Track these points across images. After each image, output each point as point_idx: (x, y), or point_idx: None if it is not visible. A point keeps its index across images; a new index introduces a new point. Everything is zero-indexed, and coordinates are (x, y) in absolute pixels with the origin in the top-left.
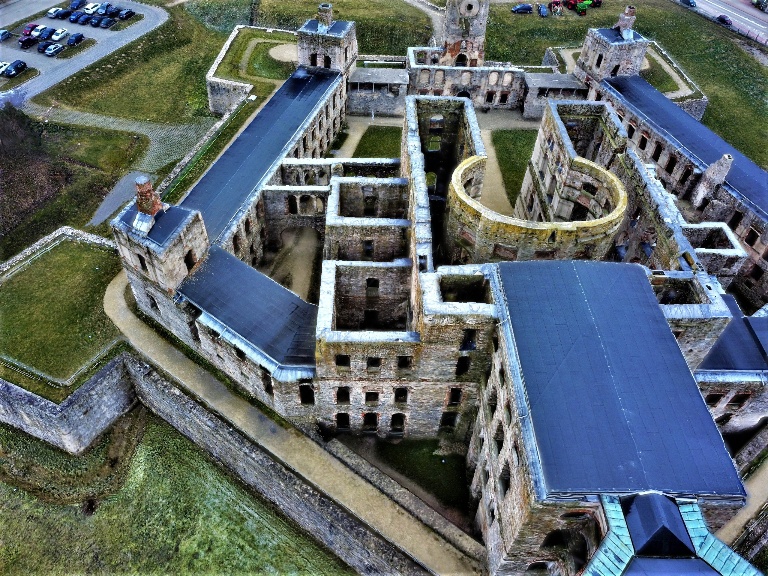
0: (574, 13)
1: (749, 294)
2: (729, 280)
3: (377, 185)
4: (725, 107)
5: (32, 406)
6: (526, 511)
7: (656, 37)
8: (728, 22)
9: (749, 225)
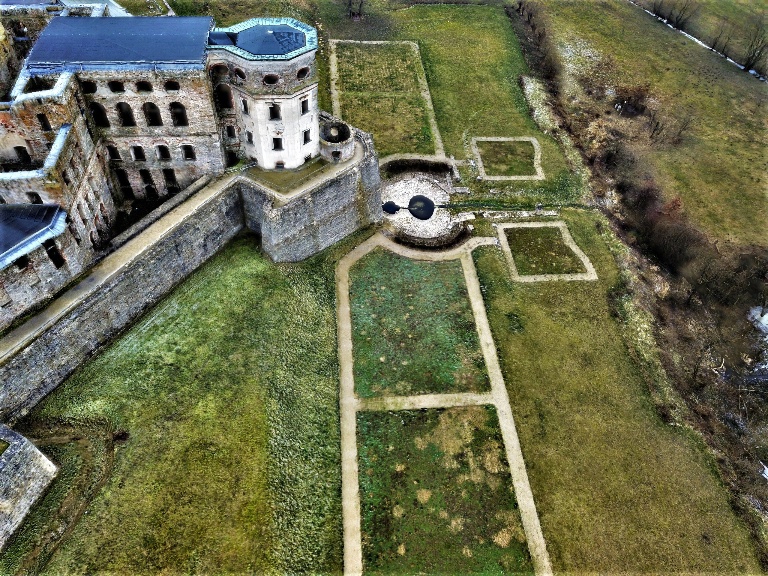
0: None
1: None
2: None
3: None
4: None
5: (4, 469)
6: (206, 86)
7: None
8: None
9: None
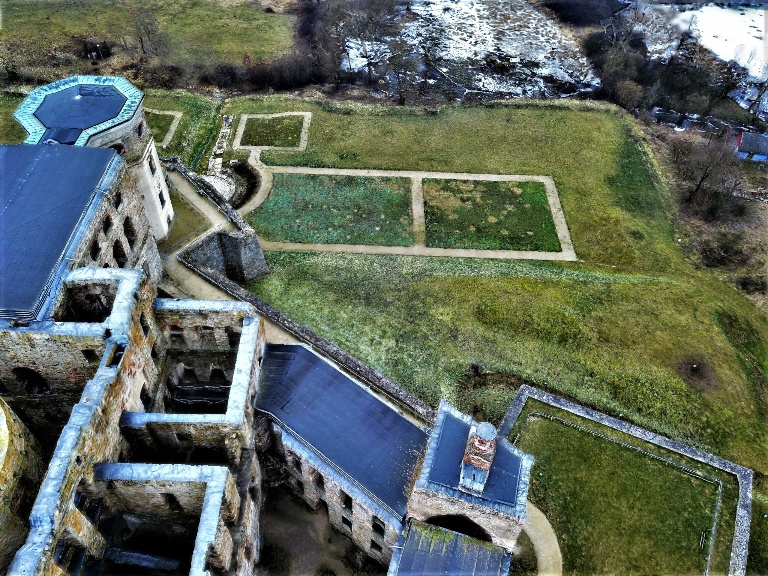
0: None
1: None
2: None
3: None
4: None
5: (553, 395)
6: None
7: None
8: None
9: None
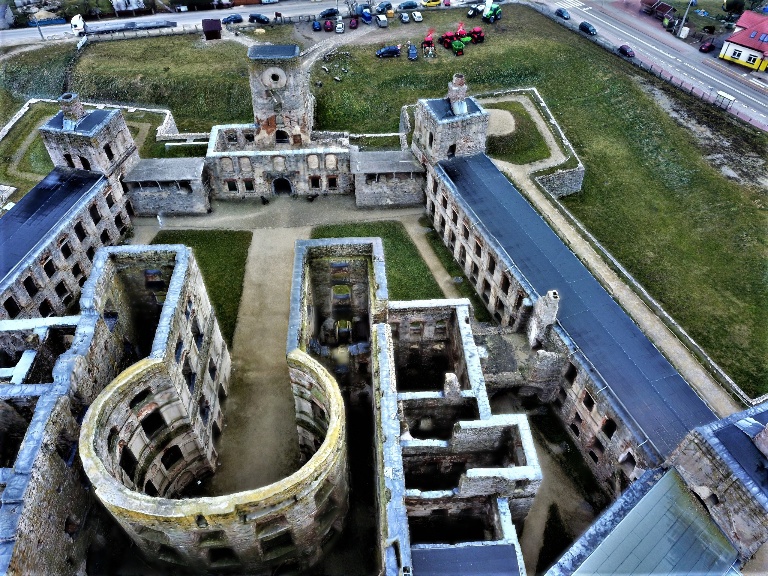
0: (450, 53)
1: (594, 470)
2: (529, 500)
3: (24, 398)
4: (612, 170)
5: None
6: None
7: (545, 77)
8: (630, 54)
9: (584, 386)
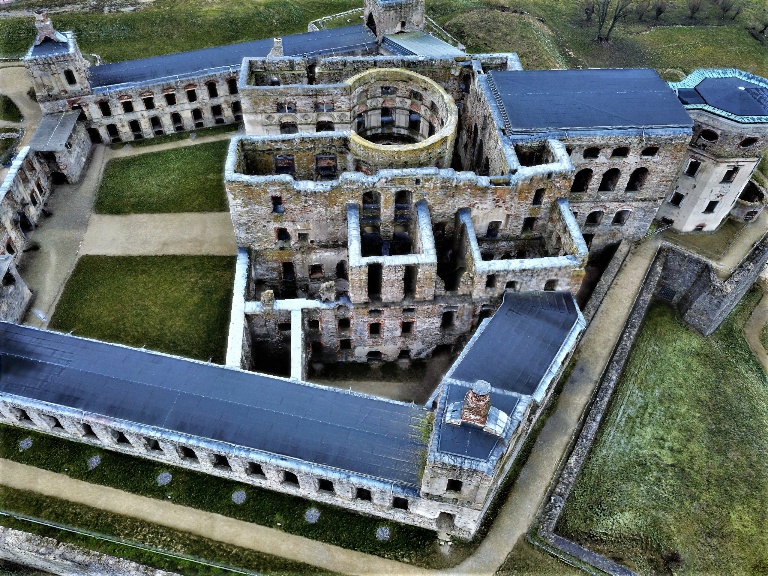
0: None
1: None
2: None
3: None
4: None
5: None
6: None
7: None
8: None
9: None
